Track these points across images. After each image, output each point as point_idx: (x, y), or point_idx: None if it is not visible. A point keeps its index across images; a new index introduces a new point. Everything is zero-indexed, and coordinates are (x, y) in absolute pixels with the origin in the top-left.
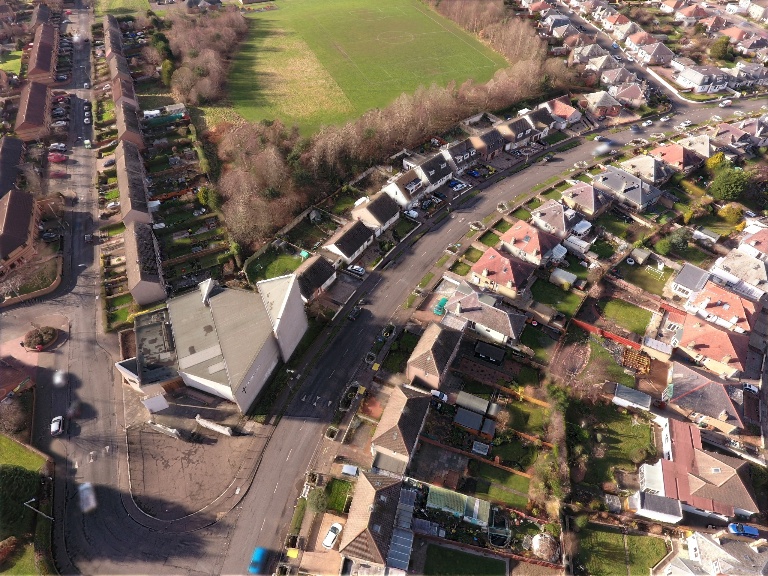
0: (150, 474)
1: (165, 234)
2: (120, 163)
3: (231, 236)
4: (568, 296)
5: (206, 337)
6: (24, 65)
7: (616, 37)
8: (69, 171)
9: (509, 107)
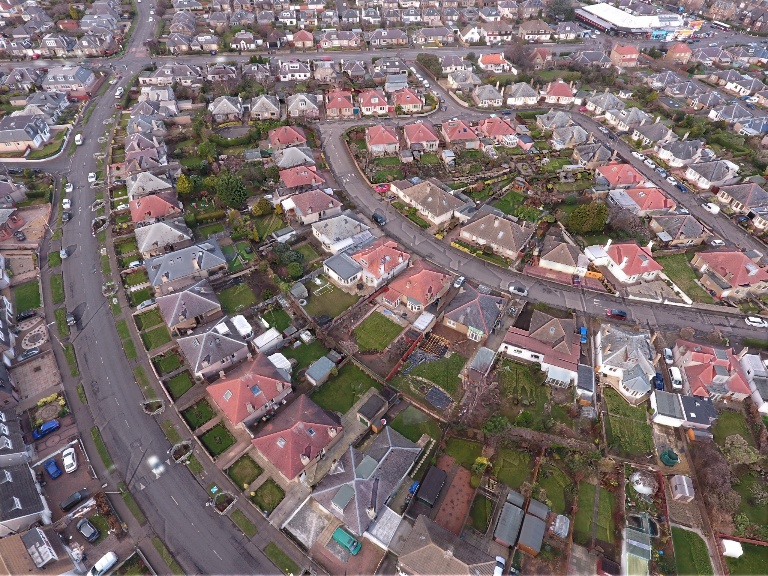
0: None
1: None
2: None
3: None
4: (344, 375)
5: None
6: None
7: None
8: None
9: None
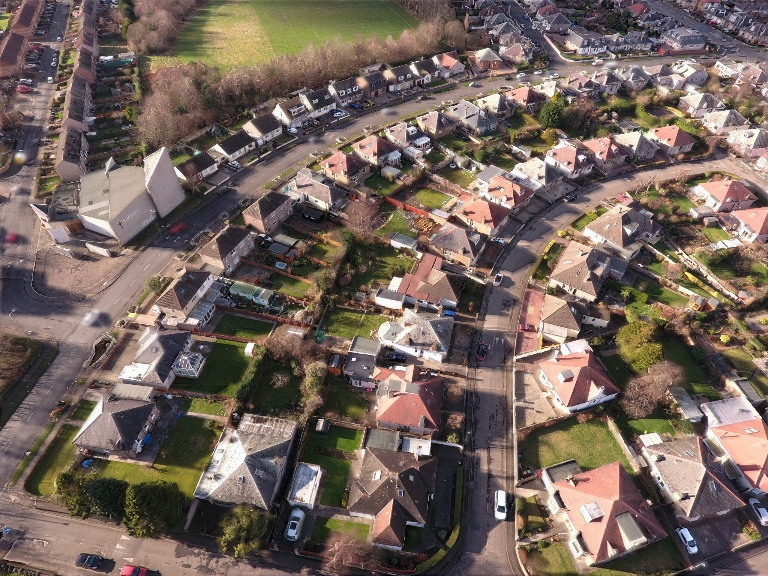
0: (48, 275)
1: (96, 140)
2: (68, 89)
3: (144, 140)
4: (392, 185)
5: (103, 196)
6: (11, 23)
7: (531, 10)
8: (32, 99)
9: (407, 60)
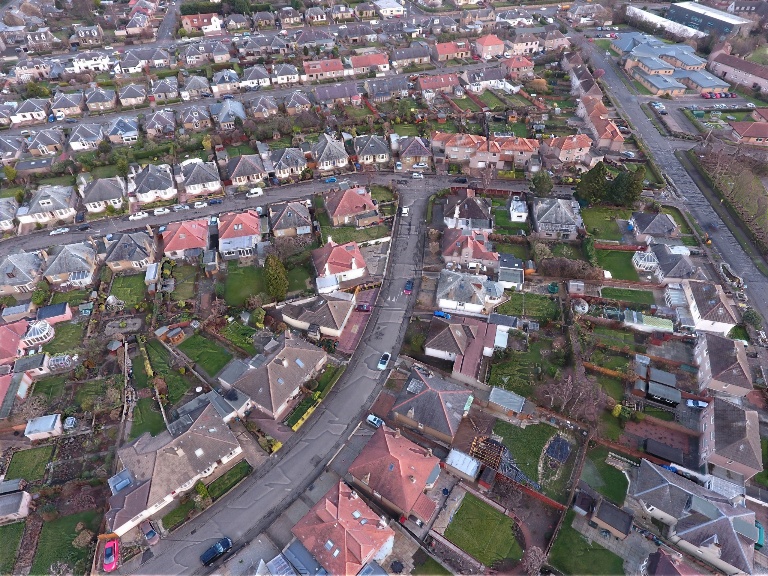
0: None
1: None
2: None
3: None
4: (568, 568)
5: None
6: None
7: None
8: None
9: None
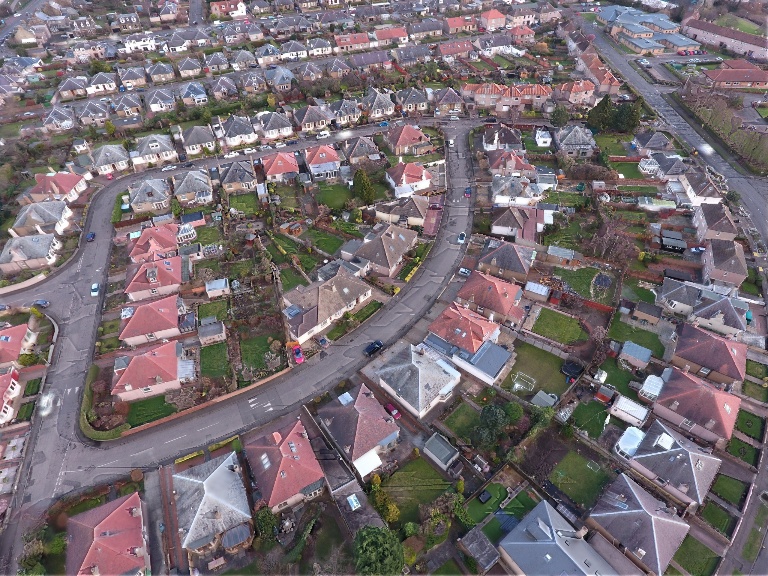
0: None
1: None
2: None
3: None
4: (622, 341)
5: None
6: None
7: None
8: None
9: None
